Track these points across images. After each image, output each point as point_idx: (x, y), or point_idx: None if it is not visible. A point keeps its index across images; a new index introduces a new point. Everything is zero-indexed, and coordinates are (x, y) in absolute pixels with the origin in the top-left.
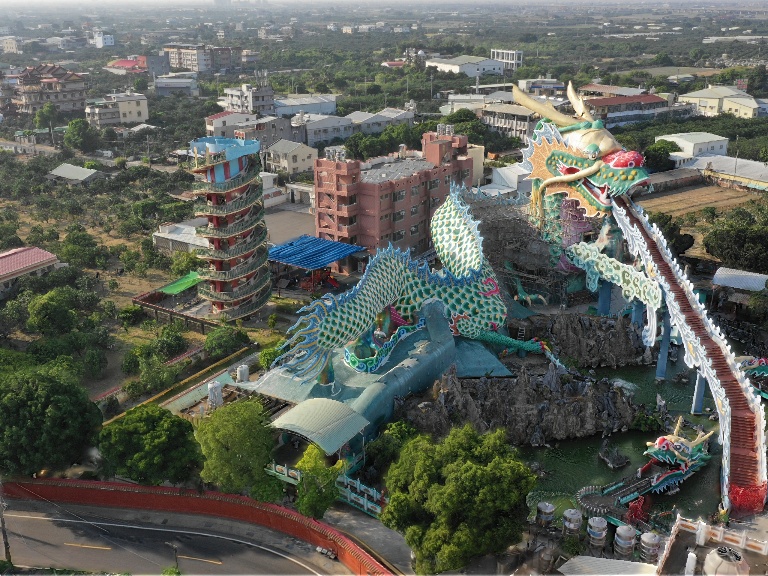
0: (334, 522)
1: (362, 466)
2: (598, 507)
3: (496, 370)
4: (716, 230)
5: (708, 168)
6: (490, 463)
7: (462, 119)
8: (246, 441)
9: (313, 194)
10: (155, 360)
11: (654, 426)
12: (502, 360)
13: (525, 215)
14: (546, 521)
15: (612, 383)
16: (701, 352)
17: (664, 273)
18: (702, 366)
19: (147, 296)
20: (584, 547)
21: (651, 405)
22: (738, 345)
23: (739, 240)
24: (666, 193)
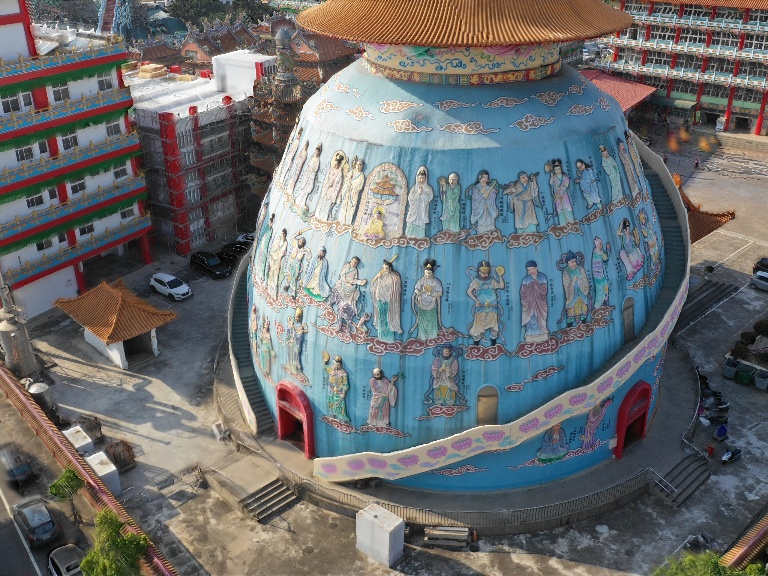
0: None
1: None
2: None
3: None
4: None
5: None
6: None
7: None
8: None
9: None
10: None
11: None
12: None
13: None
14: None
15: None
16: None
17: (111, 6)
18: None
19: None
20: None
21: None
22: None
23: (236, 7)
24: None
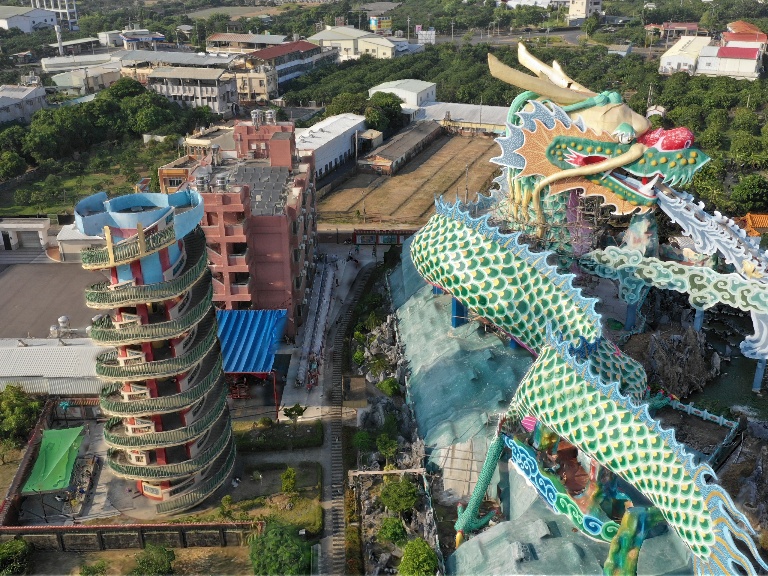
0: None
1: None
2: None
3: None
4: None
5: (448, 118)
6: None
7: (130, 91)
8: None
9: (44, 232)
10: None
11: None
12: None
13: (500, 222)
14: None
15: None
16: None
17: None
18: None
19: (6, 510)
20: None
21: None
22: (740, 321)
23: None
24: (428, 152)
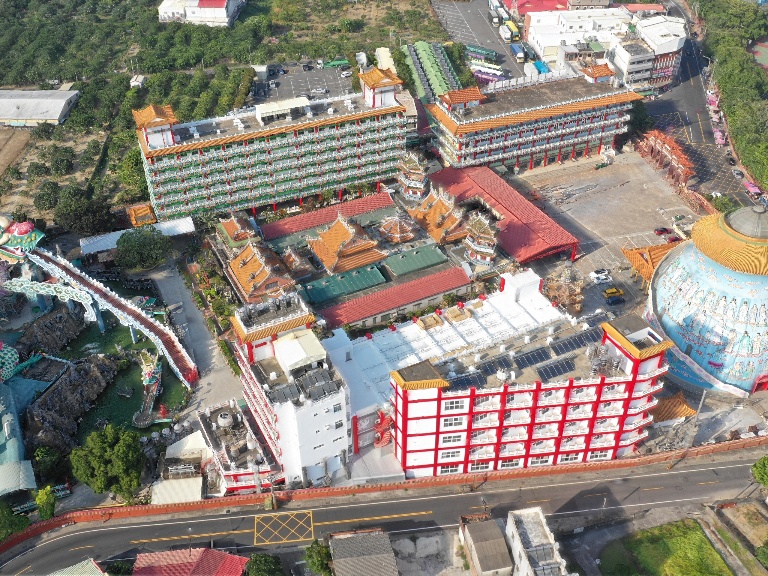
0: (54, 512)
1: (37, 481)
2: (145, 420)
3: (37, 386)
4: (40, 196)
5: None
6: (121, 441)
7: None
8: (4, 513)
9: None
10: None
11: (128, 363)
12: (27, 376)
13: None
14: (147, 444)
15: (96, 355)
16: (131, 319)
17: (82, 282)
18: (134, 325)
19: None
20: (165, 443)
21: (114, 351)
22: (117, 283)
23: (77, 217)
24: None
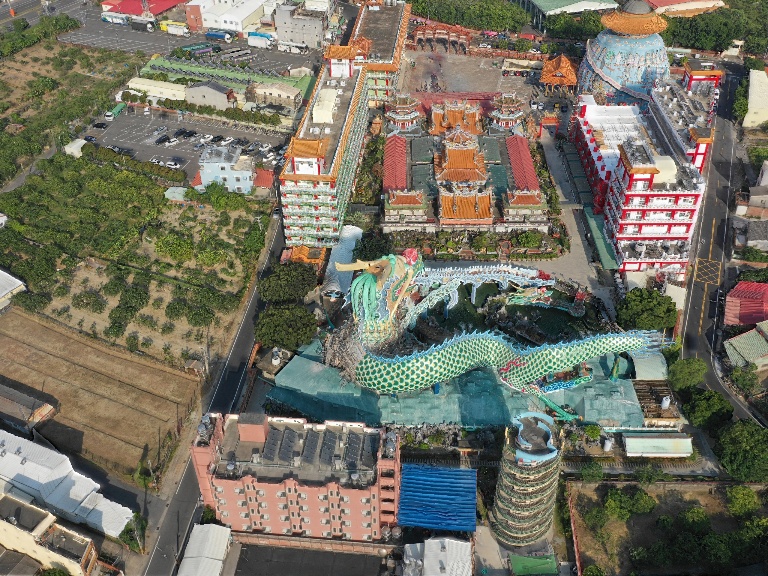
0: None
1: None
2: (578, 310)
3: None
4: None
5: None
6: None
7: None
8: None
9: None
10: (645, 479)
11: None
12: None
13: (376, 345)
14: None
15: None
16: None
17: None
18: None
19: None
20: None
21: (477, 316)
22: None
23: None
24: None
